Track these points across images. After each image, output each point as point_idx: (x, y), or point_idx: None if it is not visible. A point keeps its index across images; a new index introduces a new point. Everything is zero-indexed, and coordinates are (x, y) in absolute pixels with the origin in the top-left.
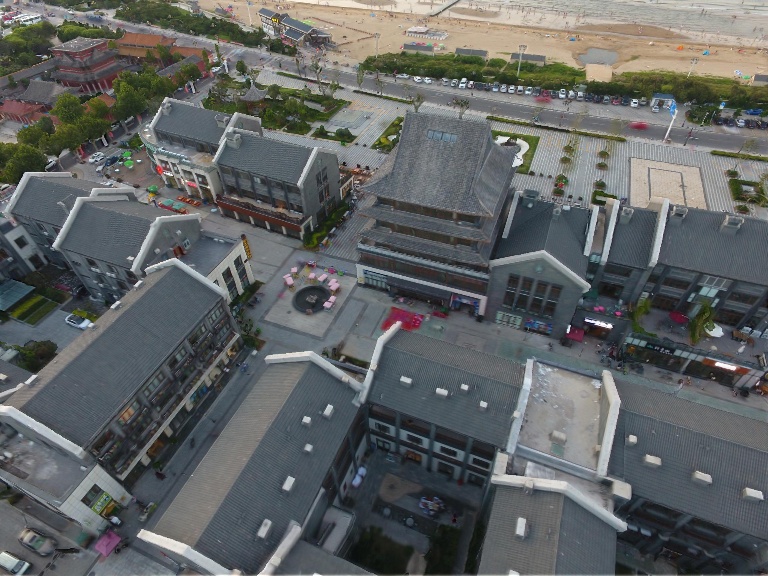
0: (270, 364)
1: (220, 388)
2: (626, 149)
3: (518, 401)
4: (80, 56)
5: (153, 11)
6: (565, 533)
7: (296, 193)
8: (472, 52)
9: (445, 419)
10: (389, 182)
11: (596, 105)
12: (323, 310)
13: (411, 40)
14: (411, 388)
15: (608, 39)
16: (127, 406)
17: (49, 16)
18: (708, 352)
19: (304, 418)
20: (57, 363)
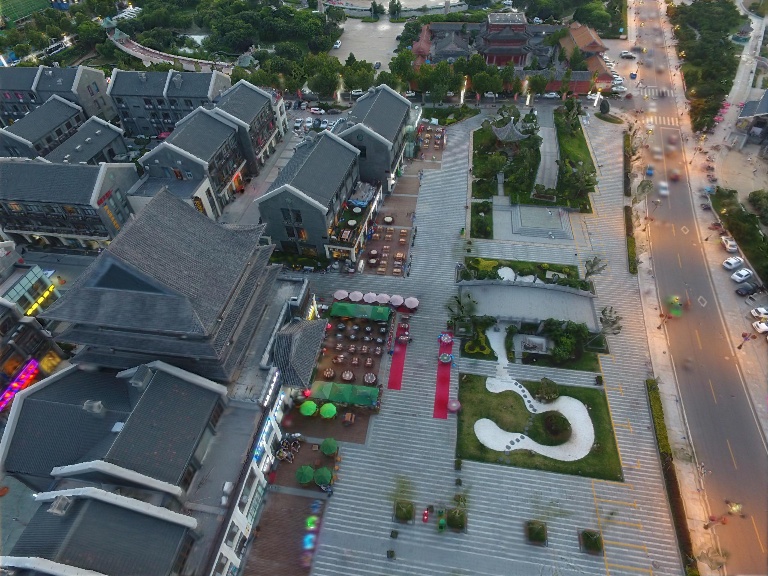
0: None
1: (85, 254)
2: None
3: None
4: (491, 28)
5: (701, 16)
6: None
7: None
8: None
9: None
10: None
11: None
12: None
13: None
14: None
15: None
16: (13, 202)
17: None
18: None
19: None
20: None
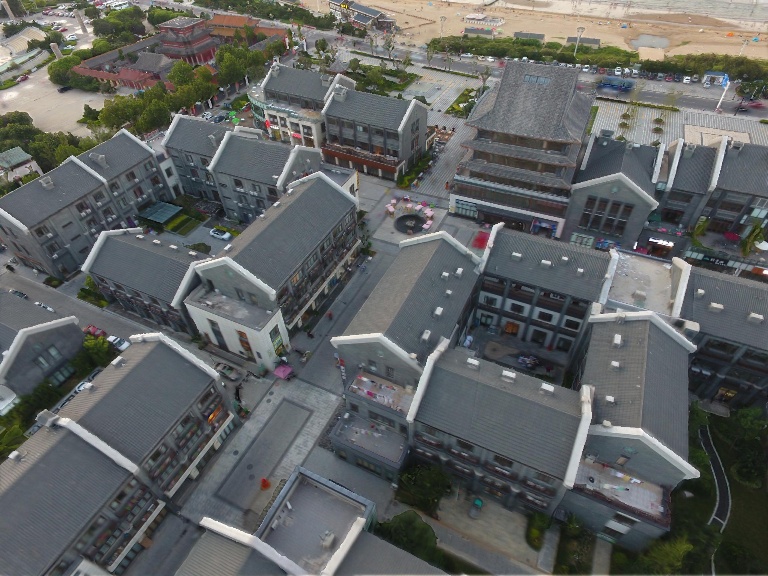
0: (404, 247)
1: (346, 281)
2: (680, 117)
3: (608, 269)
4: (183, 32)
5: None
6: (652, 342)
7: (394, 139)
8: (530, 36)
9: (548, 283)
10: (490, 118)
11: (650, 81)
12: (421, 232)
13: (469, 26)
14: (520, 262)
15: (659, 27)
16: (297, 272)
17: (134, 3)
18: (757, 261)
19: (444, 273)
20: (243, 239)
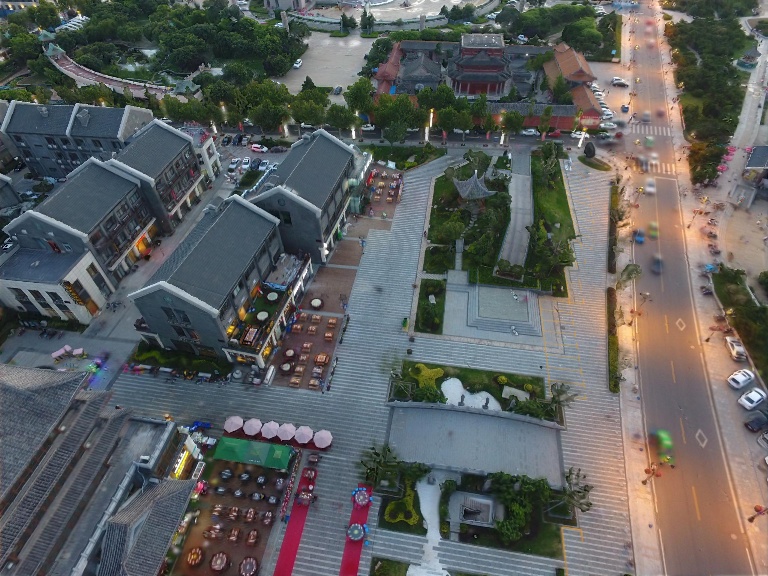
0: None
1: None
2: None
3: None
4: (464, 52)
5: (703, 36)
6: None
7: None
8: None
9: None
10: None
11: None
12: None
13: None
14: None
15: None
16: None
17: (630, 2)
18: None
19: None
20: None
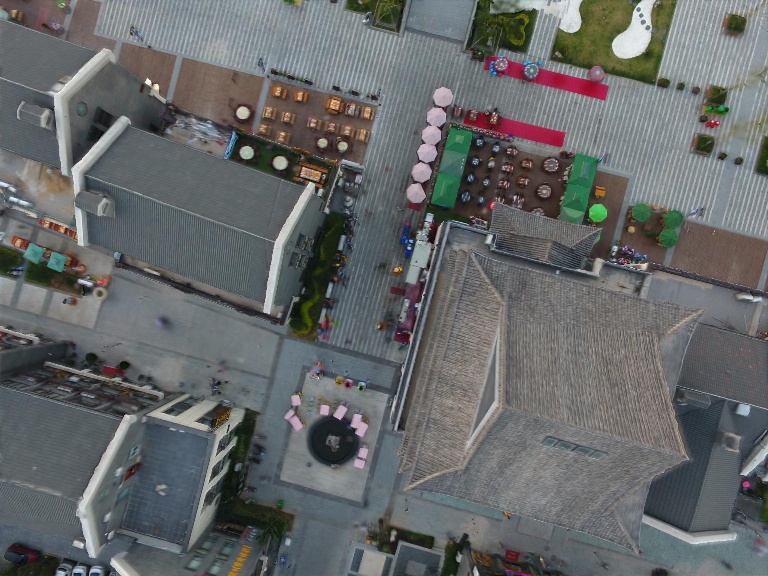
0: None
1: None
2: None
3: None
4: None
5: None
6: None
7: None
8: None
9: None
10: (460, 478)
11: None
12: (353, 460)
13: None
14: None
15: None
16: None
17: None
18: None
19: None
20: None
